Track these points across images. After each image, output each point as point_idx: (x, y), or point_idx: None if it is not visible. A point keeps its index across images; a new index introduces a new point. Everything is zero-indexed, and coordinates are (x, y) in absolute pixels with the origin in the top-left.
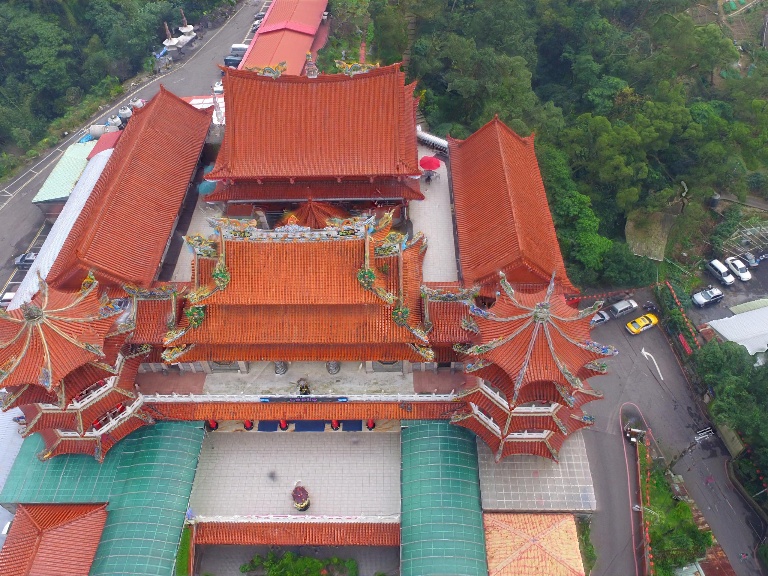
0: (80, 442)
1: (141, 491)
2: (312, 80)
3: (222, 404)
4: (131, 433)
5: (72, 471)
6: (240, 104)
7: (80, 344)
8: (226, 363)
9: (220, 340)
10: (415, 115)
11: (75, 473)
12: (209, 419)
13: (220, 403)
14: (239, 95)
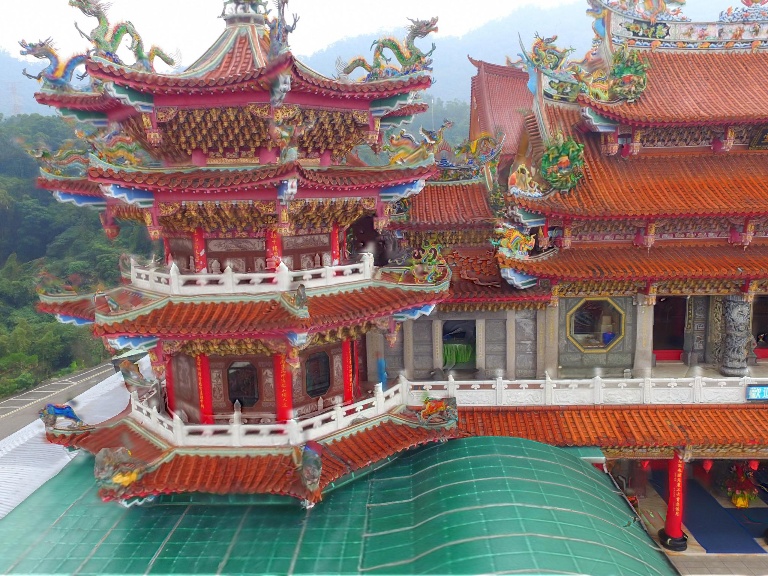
0: (234, 461)
1: (510, 568)
2: None
3: (633, 411)
4: (382, 468)
5: (194, 544)
6: (499, 100)
7: (347, 81)
8: (596, 346)
9: (635, 208)
10: None
11: (206, 549)
12: (613, 440)
13: (627, 407)
14: (497, 92)
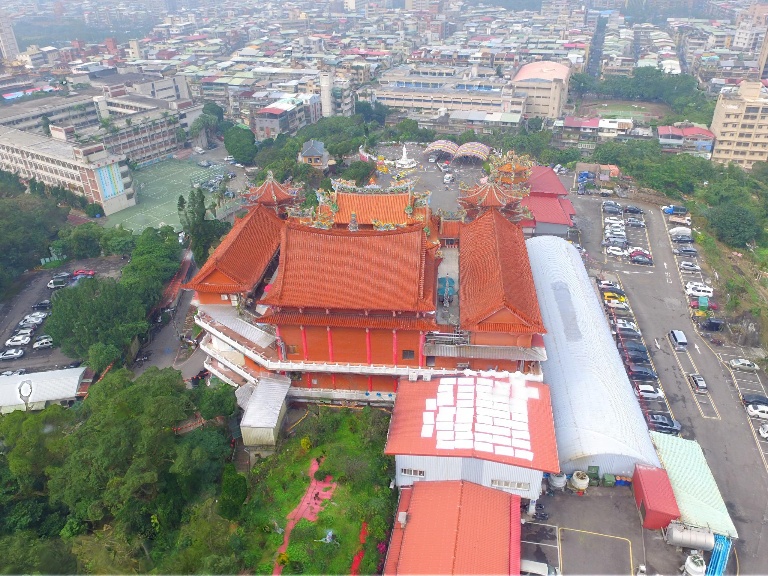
0: None
1: None
2: (355, 234)
3: None
4: None
5: None
6: None
7: None
8: None
9: None
10: (267, 311)
11: None
12: None
13: None
14: None
